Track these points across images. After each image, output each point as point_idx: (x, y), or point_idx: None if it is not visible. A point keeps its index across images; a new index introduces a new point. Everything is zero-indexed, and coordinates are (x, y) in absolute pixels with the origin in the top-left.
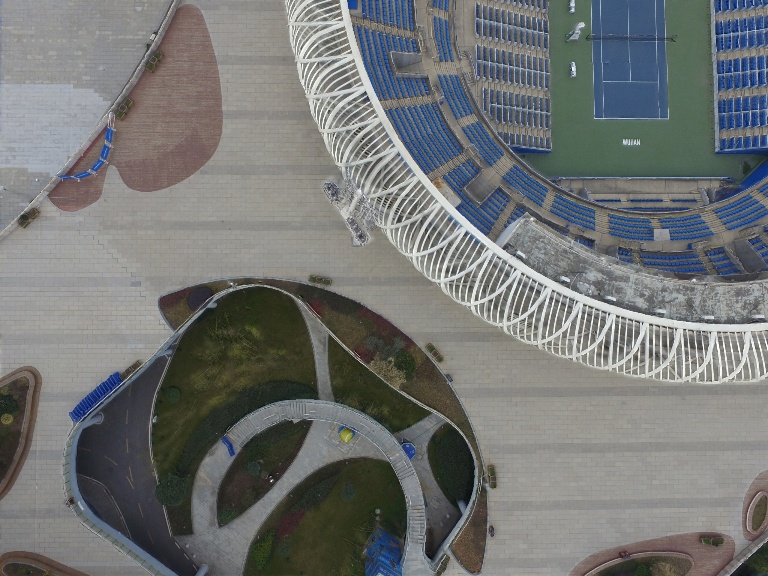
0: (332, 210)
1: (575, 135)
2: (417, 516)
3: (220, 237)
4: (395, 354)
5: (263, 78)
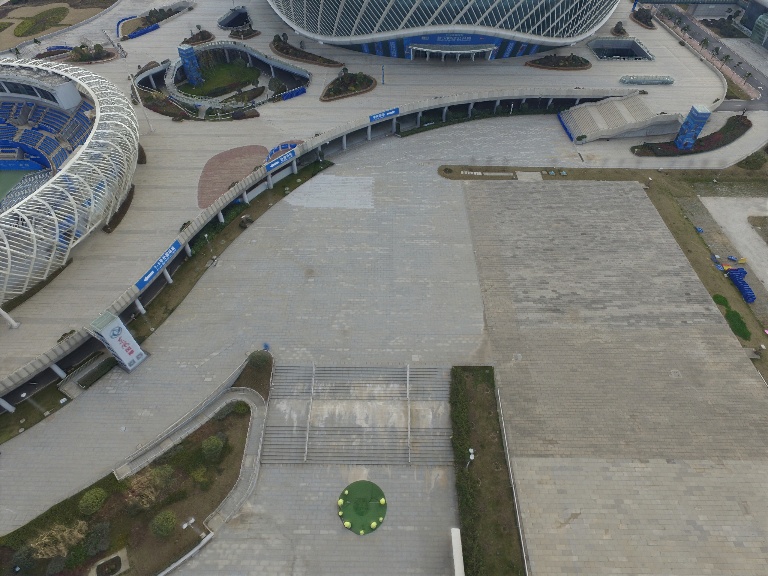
0: (160, 139)
1: (4, 186)
2: (170, 74)
3: (222, 132)
4: (153, 101)
5: (173, 181)
